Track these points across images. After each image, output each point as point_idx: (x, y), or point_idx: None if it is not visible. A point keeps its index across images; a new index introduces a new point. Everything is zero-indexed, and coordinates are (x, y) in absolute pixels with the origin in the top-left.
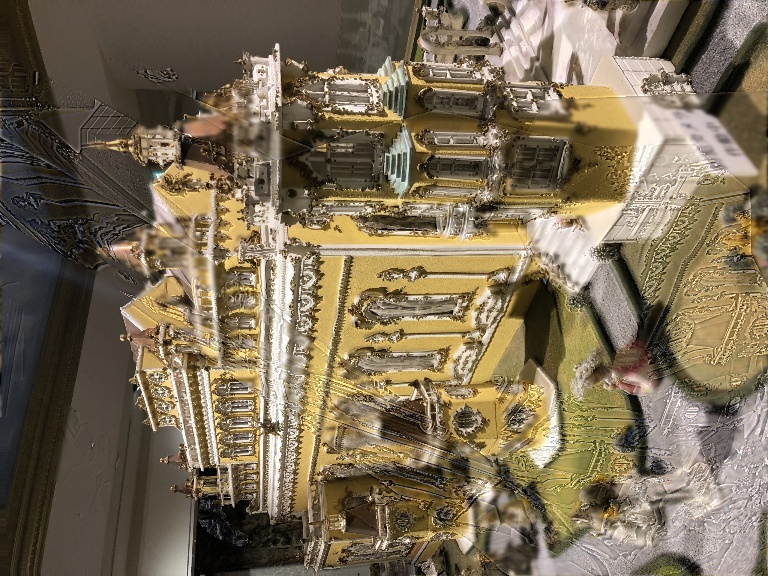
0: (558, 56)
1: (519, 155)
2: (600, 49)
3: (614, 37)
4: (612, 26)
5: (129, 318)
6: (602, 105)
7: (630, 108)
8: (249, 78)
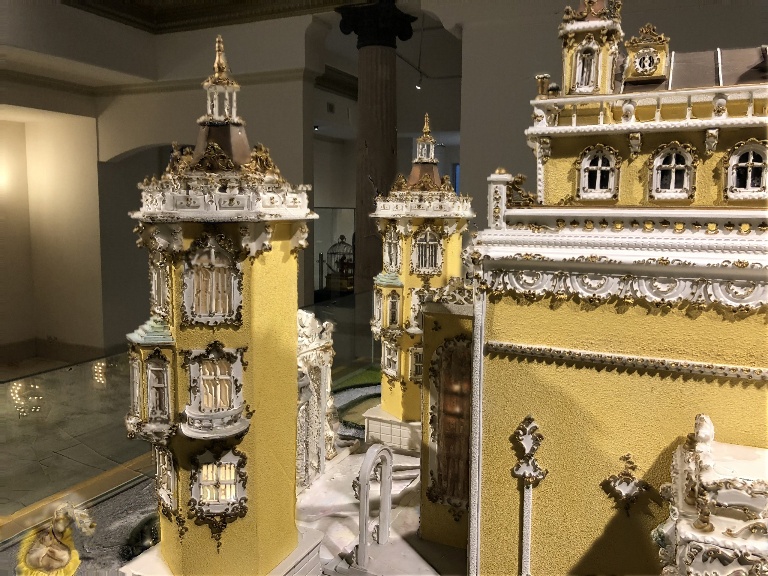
0: (375, 490)
1: None
2: None
3: None
4: (348, 444)
5: None
6: (361, 244)
7: (361, 247)
8: (390, 200)
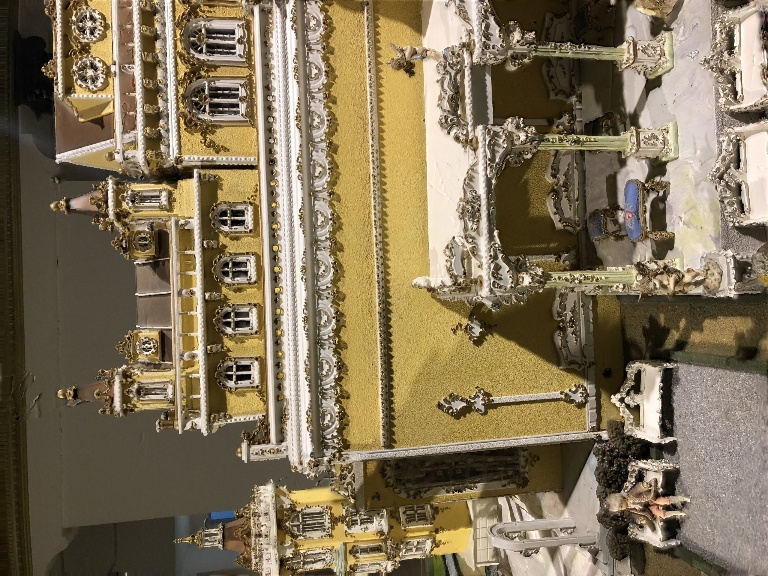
0: None
1: None
2: (515, 561)
3: (506, 573)
4: None
5: (75, 162)
6: None
7: None
8: (261, 569)
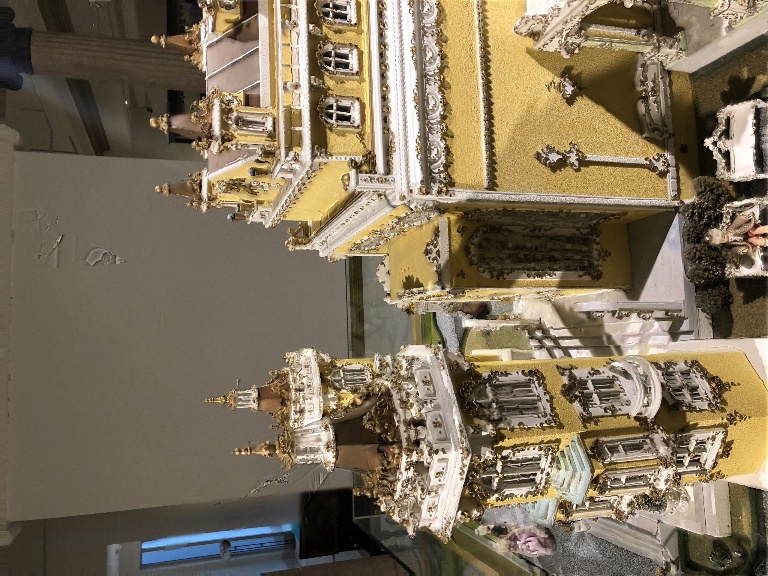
0: None
1: (292, 528)
2: None
3: None
4: None
5: None
6: None
7: None
8: None
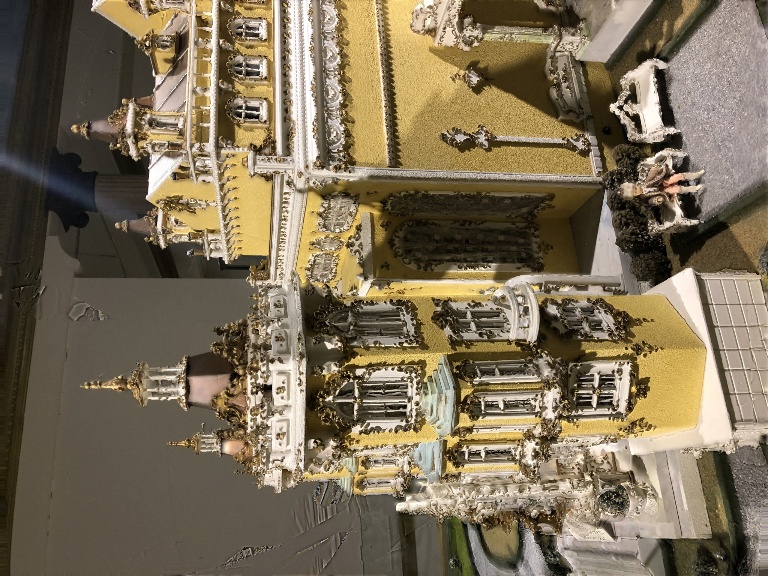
0: None
1: None
2: None
3: None
4: None
5: None
6: None
7: None
8: None
